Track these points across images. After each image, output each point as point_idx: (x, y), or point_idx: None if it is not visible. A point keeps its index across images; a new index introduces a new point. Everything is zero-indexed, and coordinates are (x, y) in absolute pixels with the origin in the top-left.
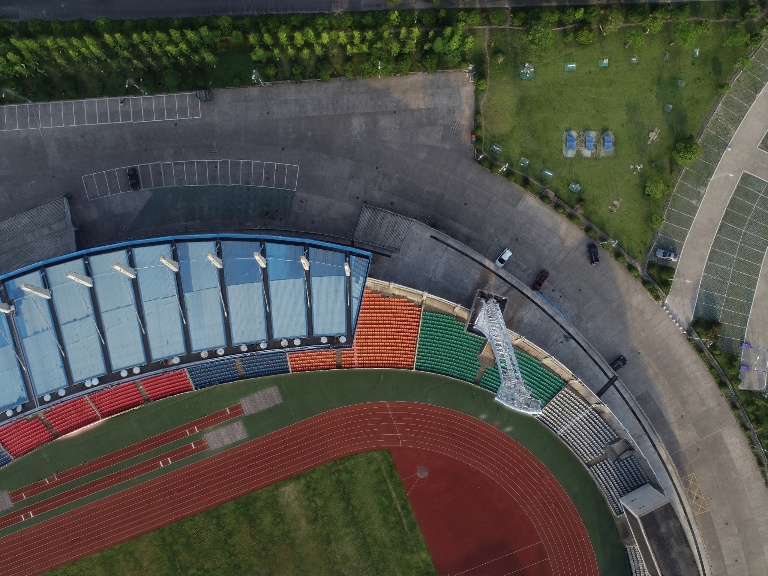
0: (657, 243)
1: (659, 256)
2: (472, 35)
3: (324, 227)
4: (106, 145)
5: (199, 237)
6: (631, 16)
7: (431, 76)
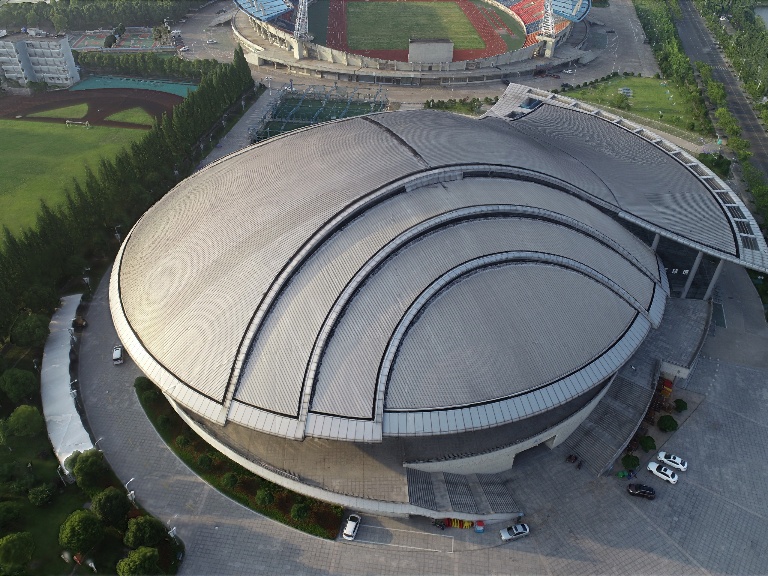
0: None
1: None
2: None
3: None
4: (625, 31)
5: None
6: None
7: None
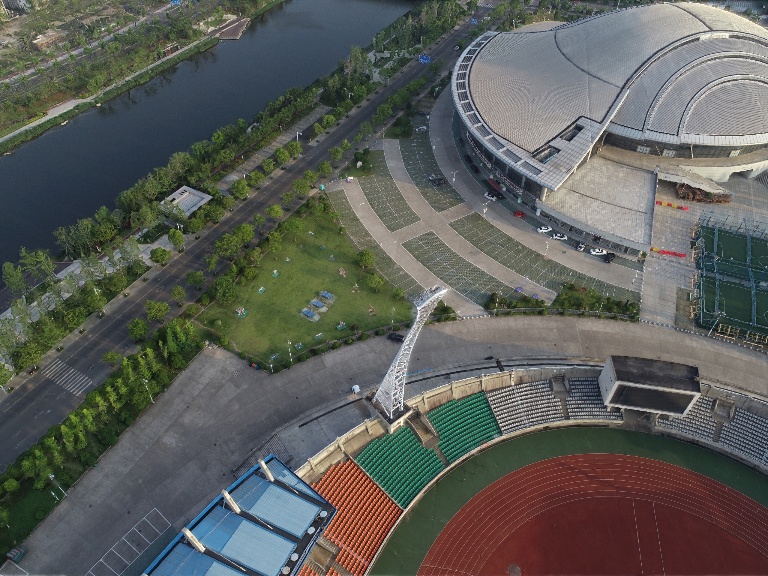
0: None
1: None
2: None
3: None
4: None
5: None
6: (261, 249)
7: (188, 370)
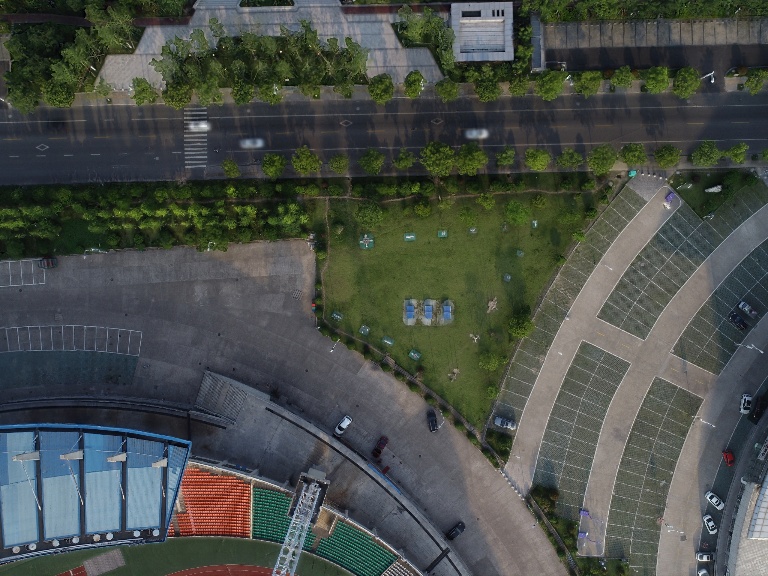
0: (496, 411)
1: (497, 424)
2: (312, 206)
3: (167, 392)
4: None
5: (18, 427)
6: (468, 189)
7: (273, 244)
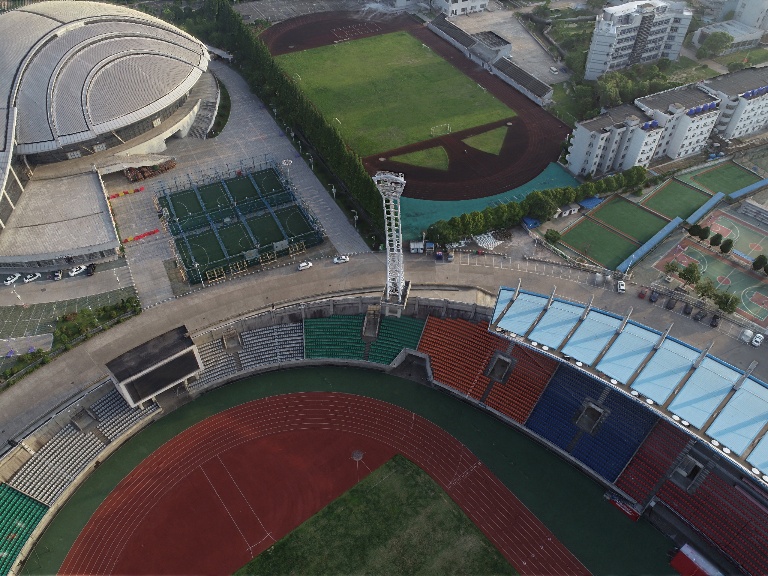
0: None
1: None
2: None
3: None
4: None
5: None
6: None
7: None
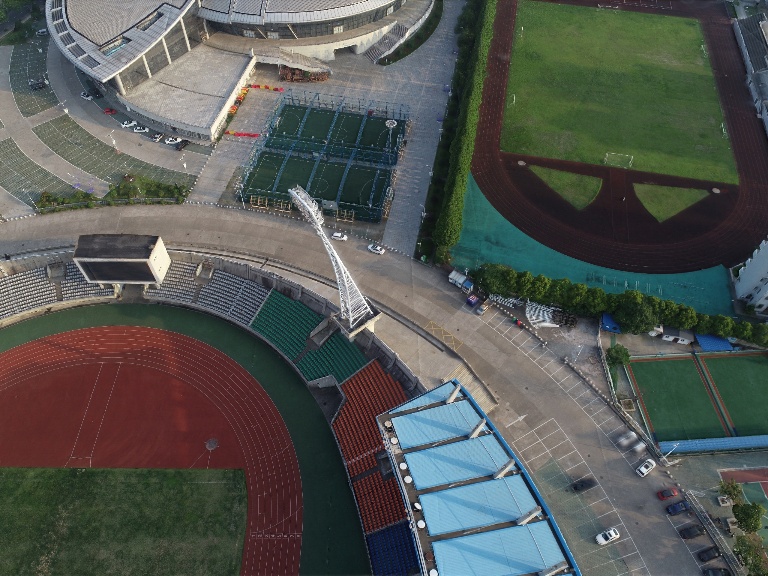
0: None
1: None
2: None
3: None
4: None
5: None
6: None
7: None
